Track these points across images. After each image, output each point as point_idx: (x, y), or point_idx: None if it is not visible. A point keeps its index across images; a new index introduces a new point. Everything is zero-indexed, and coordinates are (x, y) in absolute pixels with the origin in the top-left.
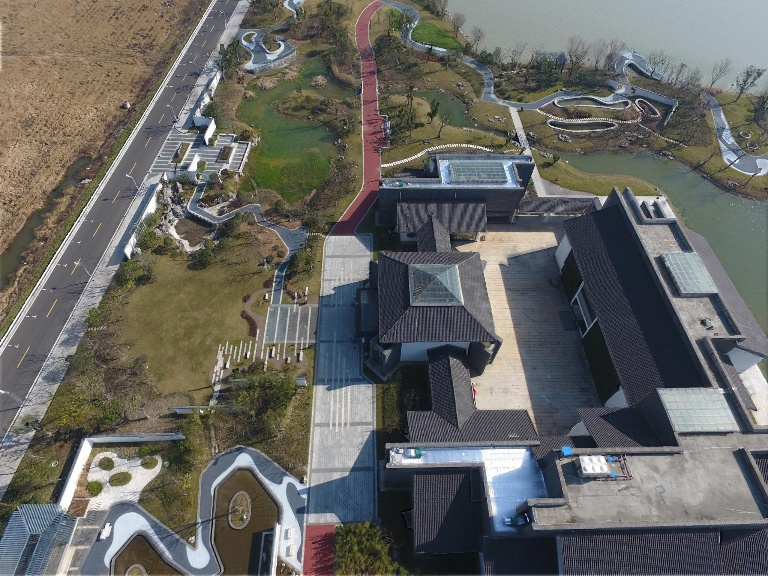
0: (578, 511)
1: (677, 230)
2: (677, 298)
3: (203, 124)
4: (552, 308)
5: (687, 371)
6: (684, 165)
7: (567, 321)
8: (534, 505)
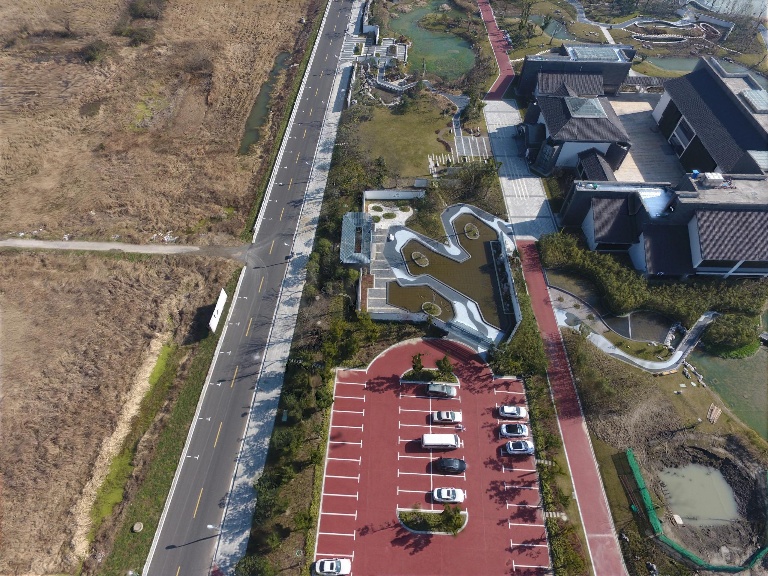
0: (705, 200)
1: (750, 81)
2: (754, 114)
3: (370, 31)
4: (655, 143)
5: (764, 149)
6: (742, 66)
7: (667, 149)
8: (679, 195)
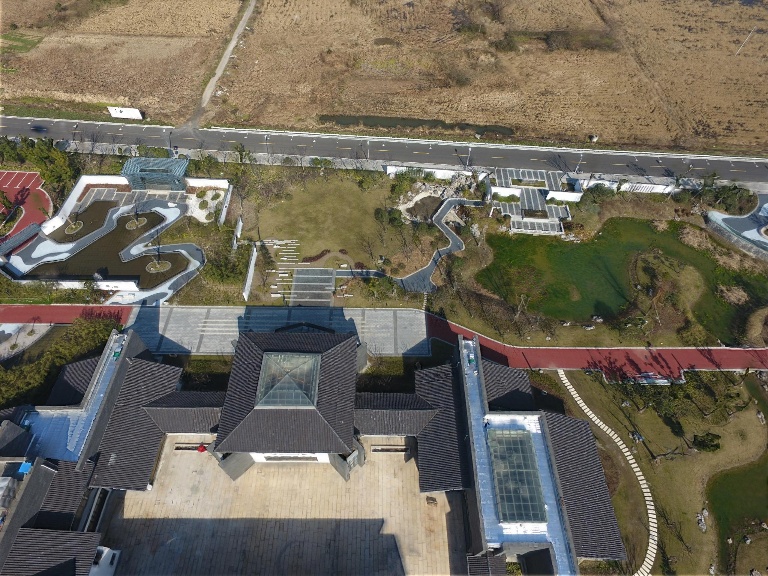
0: None
1: None
2: None
3: None
4: None
5: None
6: None
7: None
8: None
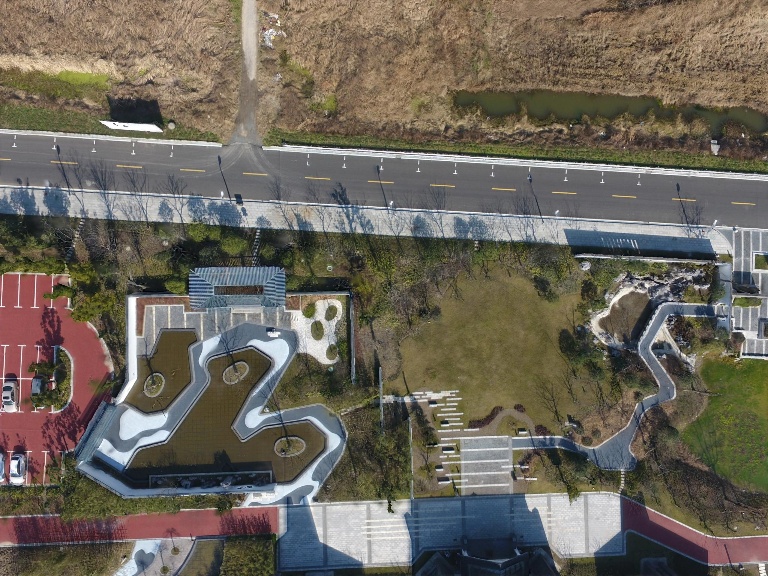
0: None
1: None
2: None
3: None
4: None
5: None
6: None
7: None
8: None
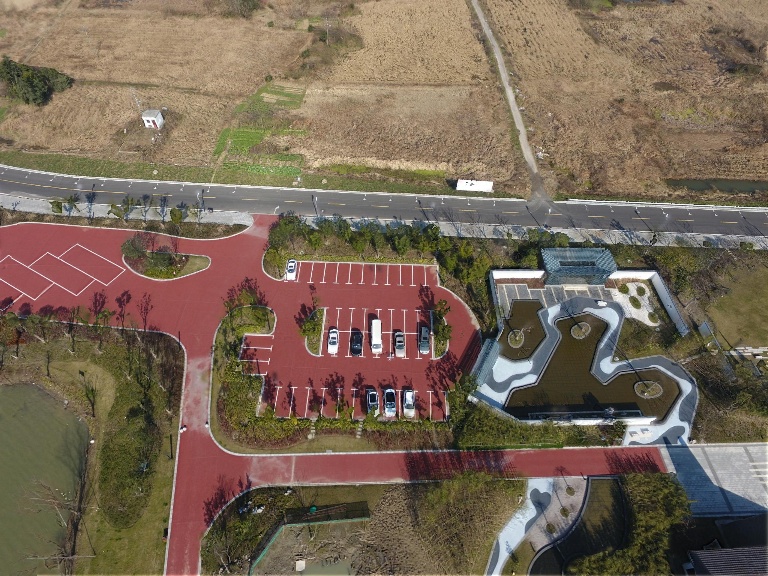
0: None
1: None
2: None
3: None
4: None
5: None
6: None
7: None
8: None
